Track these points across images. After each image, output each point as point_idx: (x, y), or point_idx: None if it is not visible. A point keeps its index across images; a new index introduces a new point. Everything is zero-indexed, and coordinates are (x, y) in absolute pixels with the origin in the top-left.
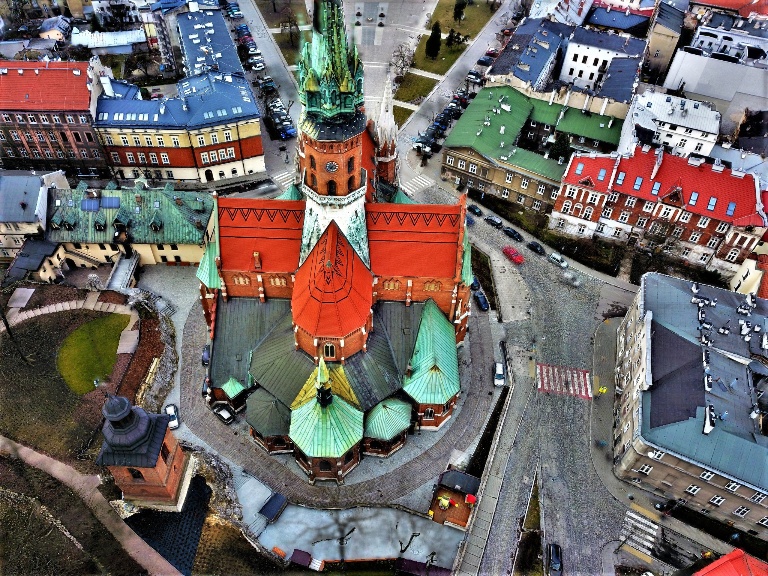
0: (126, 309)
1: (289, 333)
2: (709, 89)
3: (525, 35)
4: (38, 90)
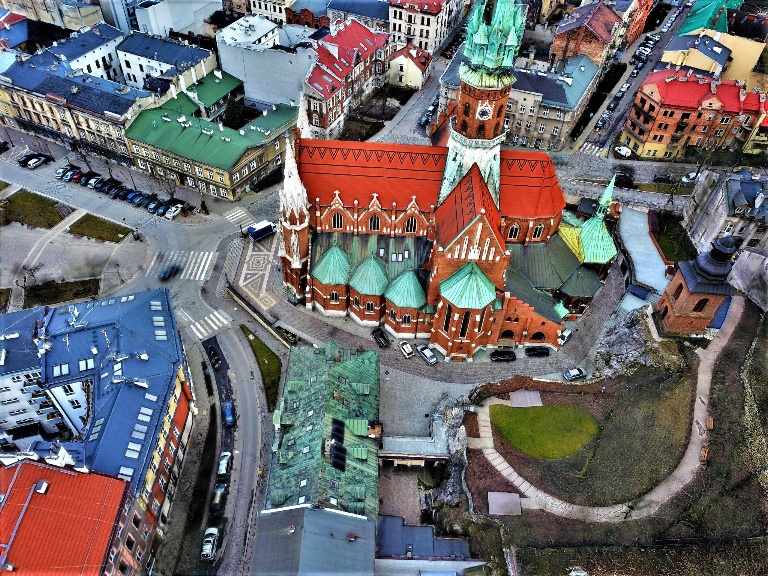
0: (482, 411)
1: (529, 250)
2: (180, 23)
3: (46, 81)
4: (53, 571)
